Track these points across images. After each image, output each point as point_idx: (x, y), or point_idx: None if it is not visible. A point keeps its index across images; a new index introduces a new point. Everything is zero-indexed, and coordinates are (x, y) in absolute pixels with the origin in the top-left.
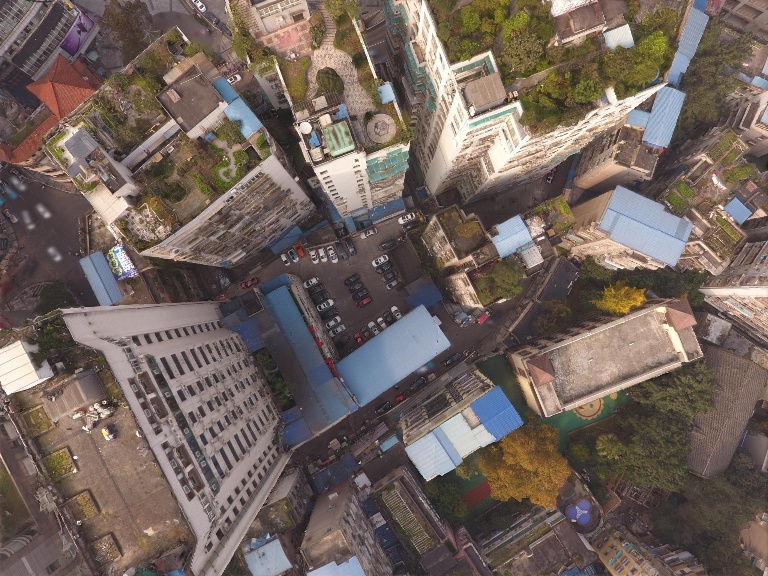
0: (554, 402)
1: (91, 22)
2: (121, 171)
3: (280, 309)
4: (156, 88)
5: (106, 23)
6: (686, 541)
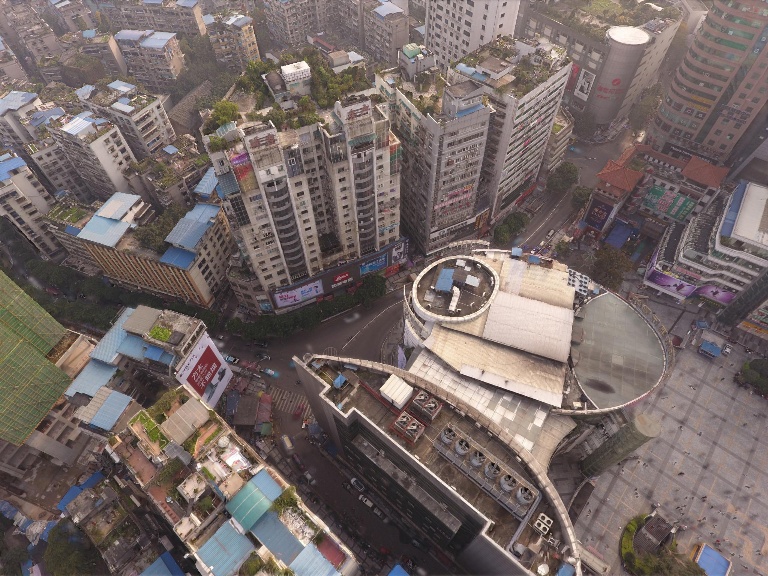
0: None
1: (649, 277)
2: (523, 48)
3: None
4: (517, 73)
5: (644, 296)
6: None
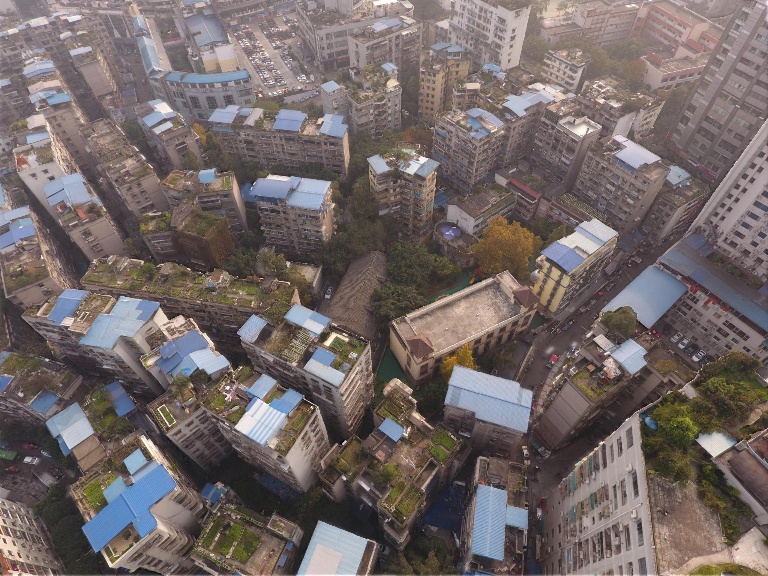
0: (505, 280)
1: None
2: None
3: (765, 316)
4: None
5: None
6: (388, 216)
